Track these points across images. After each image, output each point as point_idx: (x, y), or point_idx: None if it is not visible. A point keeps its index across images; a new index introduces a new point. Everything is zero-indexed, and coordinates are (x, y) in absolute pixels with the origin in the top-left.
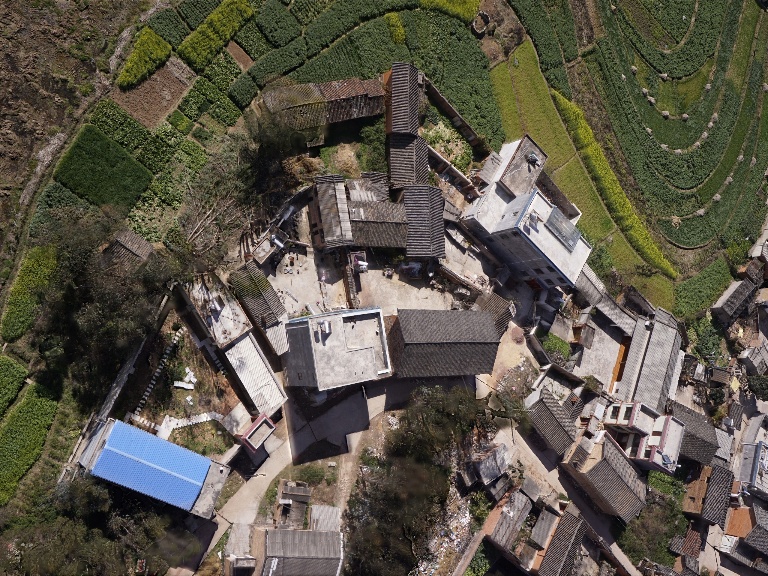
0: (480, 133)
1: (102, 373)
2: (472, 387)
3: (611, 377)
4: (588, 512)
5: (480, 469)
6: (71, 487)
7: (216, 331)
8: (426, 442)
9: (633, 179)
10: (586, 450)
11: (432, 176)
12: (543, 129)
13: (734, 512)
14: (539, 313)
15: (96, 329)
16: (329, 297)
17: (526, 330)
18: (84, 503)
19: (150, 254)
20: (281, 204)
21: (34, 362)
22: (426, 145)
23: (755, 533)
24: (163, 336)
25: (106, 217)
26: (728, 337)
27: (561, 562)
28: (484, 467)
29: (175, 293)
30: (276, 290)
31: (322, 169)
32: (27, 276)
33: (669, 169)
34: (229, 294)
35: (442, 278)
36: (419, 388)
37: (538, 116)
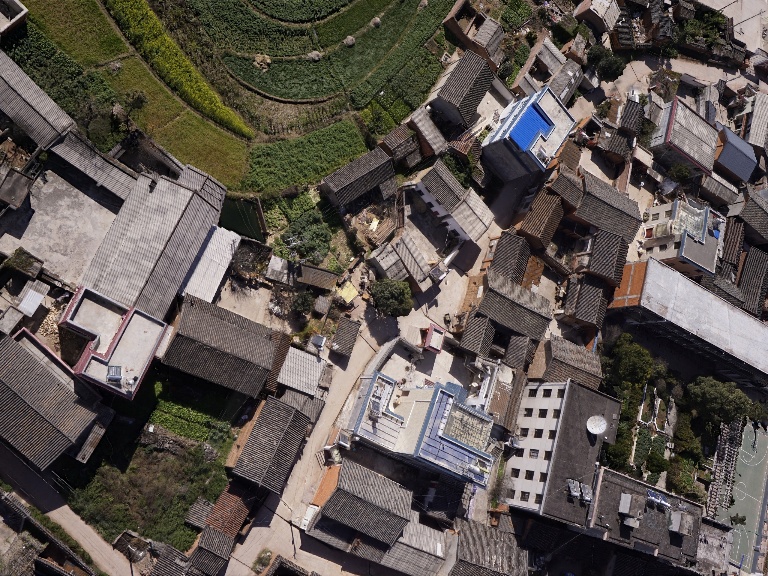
0: None
1: None
2: None
3: None
4: (8, 456)
5: None
6: None
7: None
8: None
9: None
10: None
11: None
12: None
13: (327, 472)
14: None
15: None
16: None
17: None
18: None
19: None
20: None
21: None
22: None
23: (337, 500)
24: None
25: None
26: (347, 228)
27: None
28: None
29: None
30: None
31: None
32: None
33: None
34: None
35: None
36: None
37: None
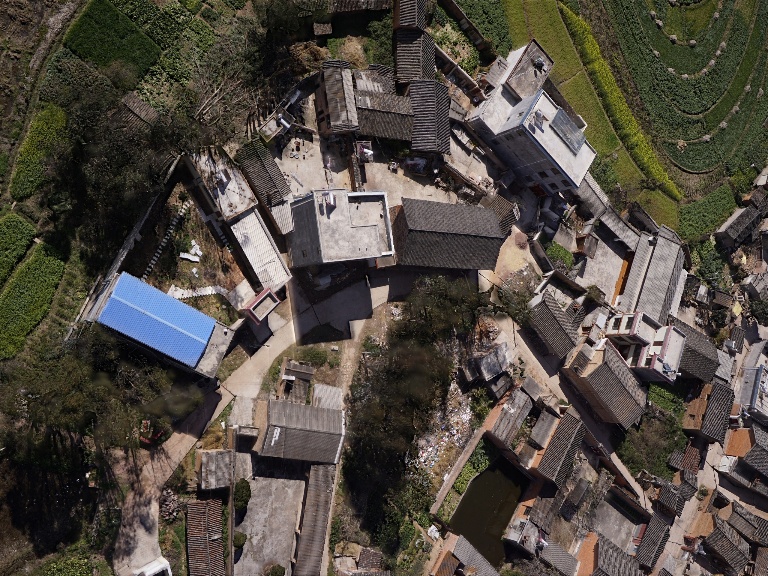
0: (487, 38)
1: (109, 238)
2: (475, 287)
3: (613, 291)
4: (588, 420)
5: (481, 365)
6: (78, 342)
7: (222, 203)
8: (428, 327)
9: (639, 99)
10: (587, 356)
11: (438, 76)
12: (550, 41)
13: (734, 433)
14: (543, 221)
15: (104, 184)
16: (334, 185)
17: (530, 236)
18: (90, 362)
19: (158, 123)
20: (288, 90)
21: (42, 222)
22: (433, 43)
23: (754, 452)
24: (170, 207)
25: (115, 88)
26: (731, 263)
27: (560, 460)
28: (485, 363)
29: (182, 166)
30: (282, 173)
31: (329, 59)
32: (36, 137)
33: (676, 93)
34: (235, 169)
35: (447, 177)
36: (422, 278)
37: (545, 28)
